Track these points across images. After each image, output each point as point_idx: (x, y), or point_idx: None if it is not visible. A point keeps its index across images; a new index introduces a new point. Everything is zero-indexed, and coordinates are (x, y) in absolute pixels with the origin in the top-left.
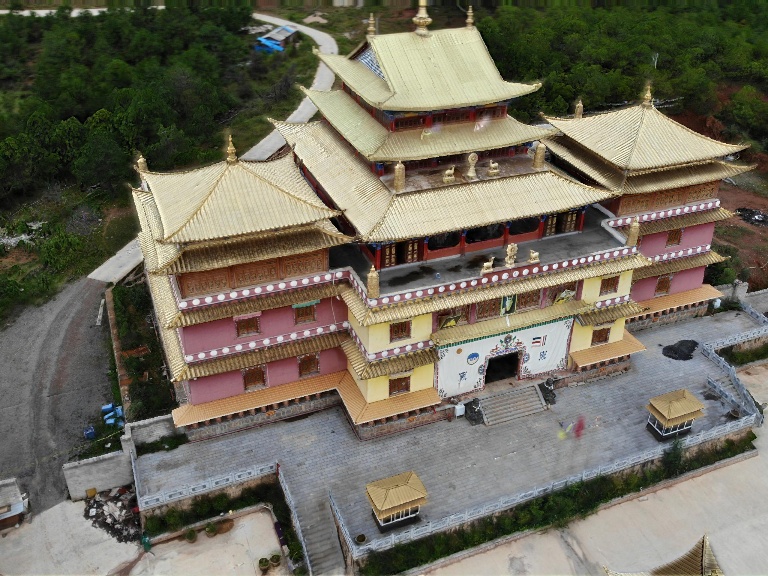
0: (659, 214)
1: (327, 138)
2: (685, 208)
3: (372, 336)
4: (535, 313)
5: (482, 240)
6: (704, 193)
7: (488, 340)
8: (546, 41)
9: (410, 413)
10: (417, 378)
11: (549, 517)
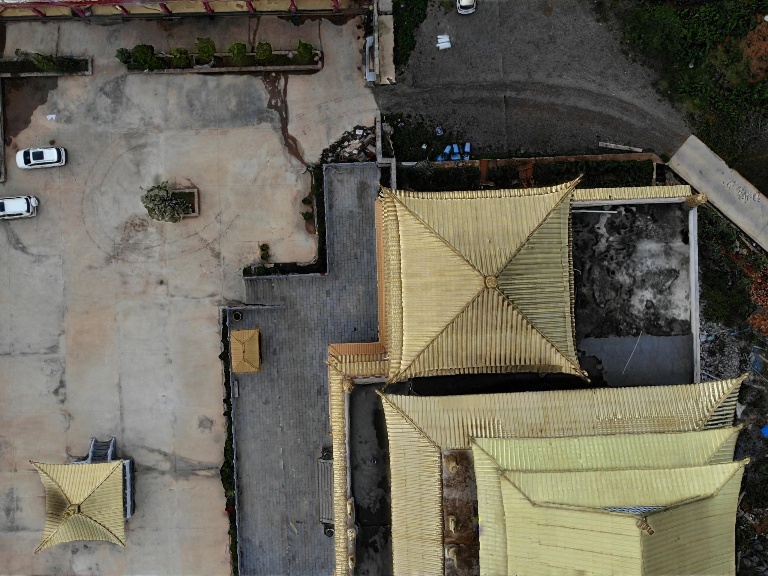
0: None
1: (644, 430)
2: None
3: None
4: None
5: None
6: None
7: None
8: None
9: None
10: None
11: None
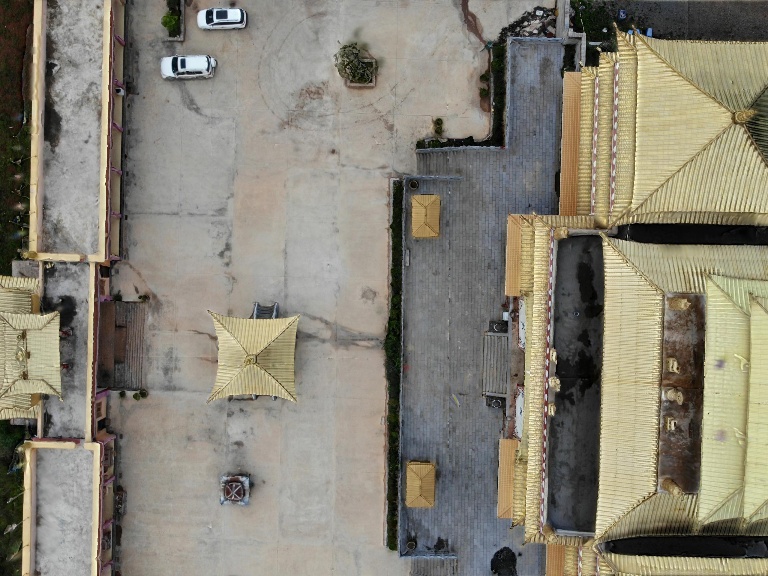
0: None
1: None
2: None
3: None
4: None
5: None
6: None
7: None
8: None
9: None
10: None
11: None
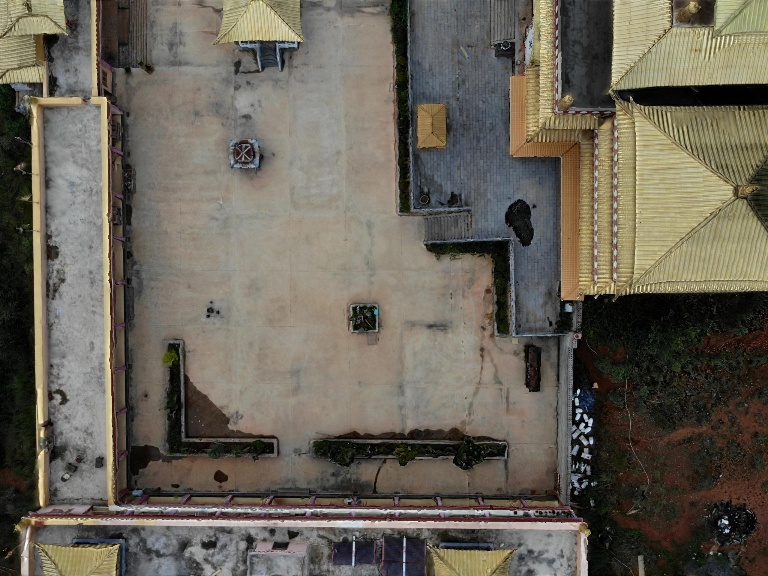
0: None
1: None
2: None
3: None
4: None
5: None
6: None
7: None
8: None
9: None
10: None
11: None
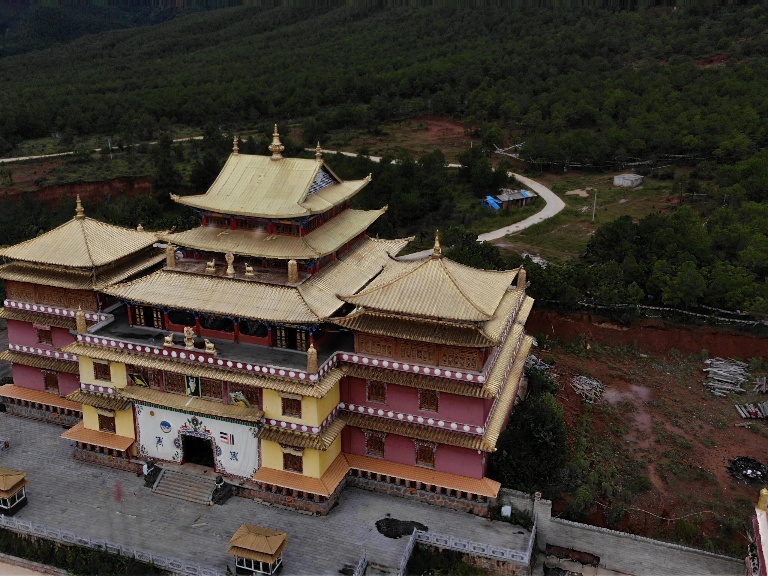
0: (403, 366)
1: None
2: (436, 370)
3: (82, 367)
4: (217, 405)
5: (219, 330)
6: (464, 361)
7: (176, 414)
8: (706, 234)
9: (111, 452)
10: (121, 423)
11: (92, 573)
